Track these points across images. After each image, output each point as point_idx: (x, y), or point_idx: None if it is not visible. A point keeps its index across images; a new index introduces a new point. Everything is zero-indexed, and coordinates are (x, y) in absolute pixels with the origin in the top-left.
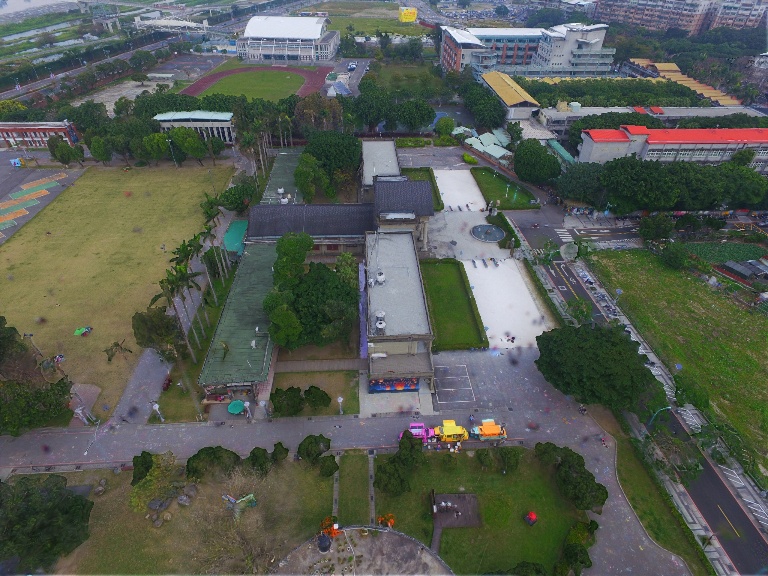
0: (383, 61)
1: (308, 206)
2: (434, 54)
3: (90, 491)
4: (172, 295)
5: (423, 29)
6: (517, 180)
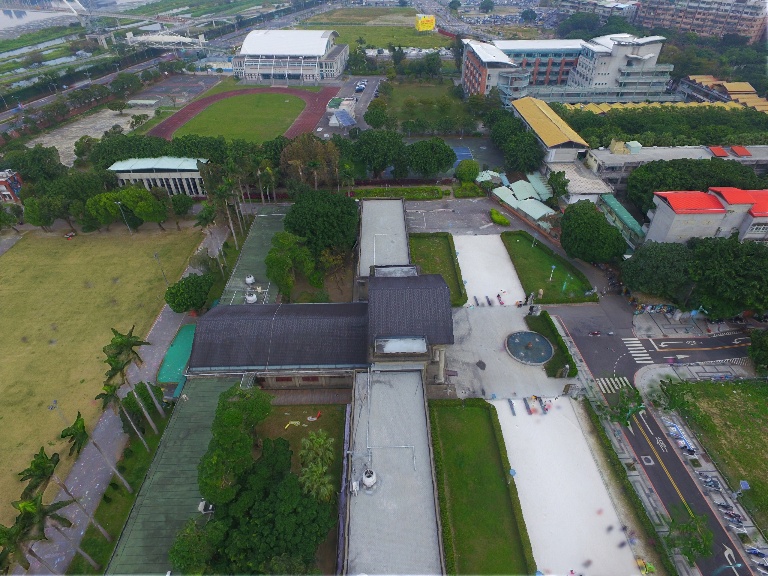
0: (396, 79)
1: (278, 317)
2: (454, 69)
3: None
4: (4, 563)
5: (442, 38)
6: (563, 251)
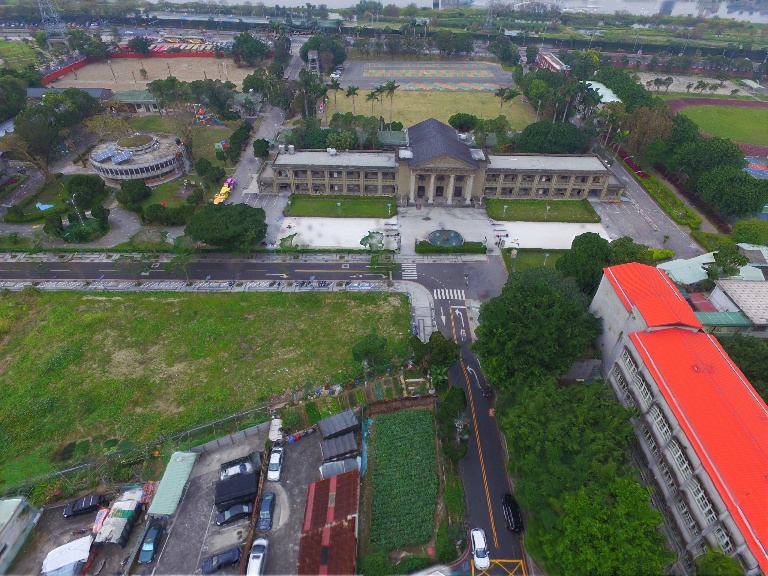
0: None
1: (436, 133)
2: None
3: None
4: None
5: None
6: None
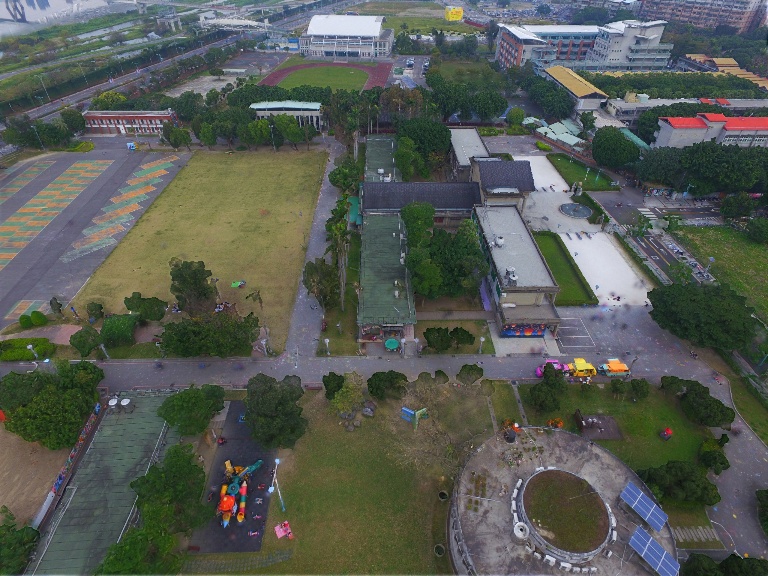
0: (438, 58)
1: (415, 183)
2: (487, 51)
3: None
4: (336, 248)
5: (470, 27)
6: (592, 165)
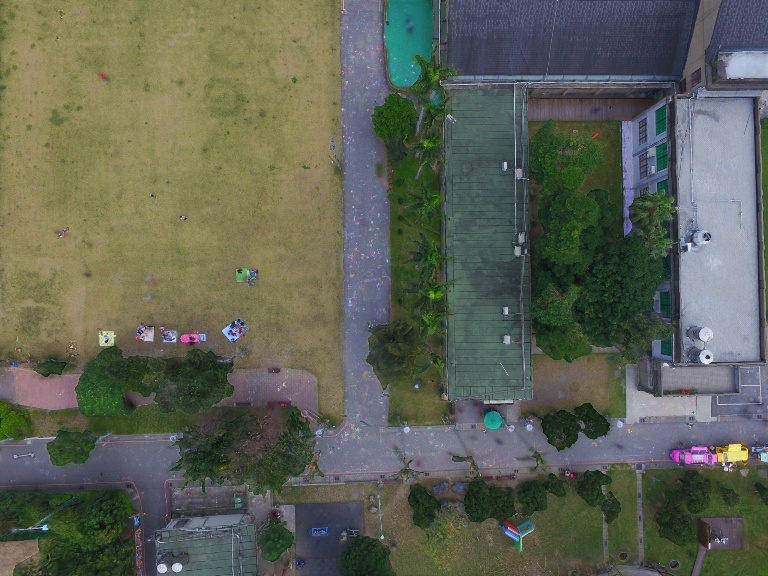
0: None
1: None
2: None
3: (363, 508)
4: None
5: None
6: None
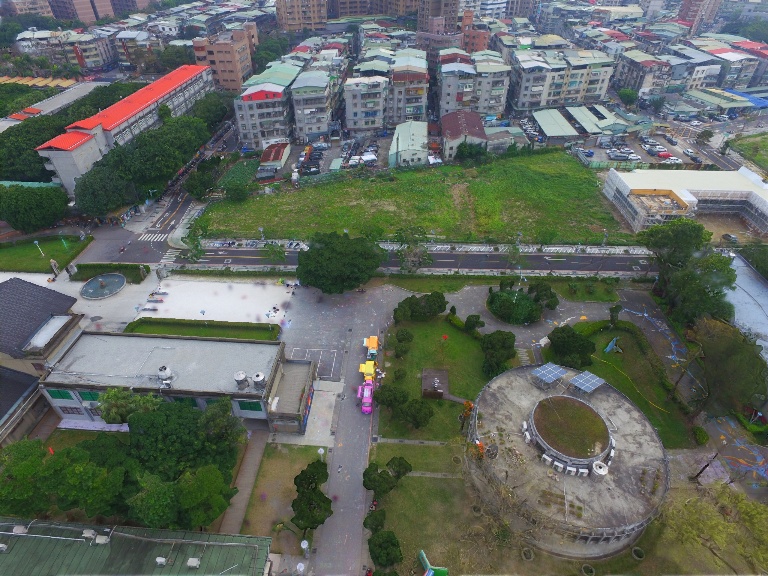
0: None
1: None
2: None
3: None
4: None
5: None
6: (16, 238)
